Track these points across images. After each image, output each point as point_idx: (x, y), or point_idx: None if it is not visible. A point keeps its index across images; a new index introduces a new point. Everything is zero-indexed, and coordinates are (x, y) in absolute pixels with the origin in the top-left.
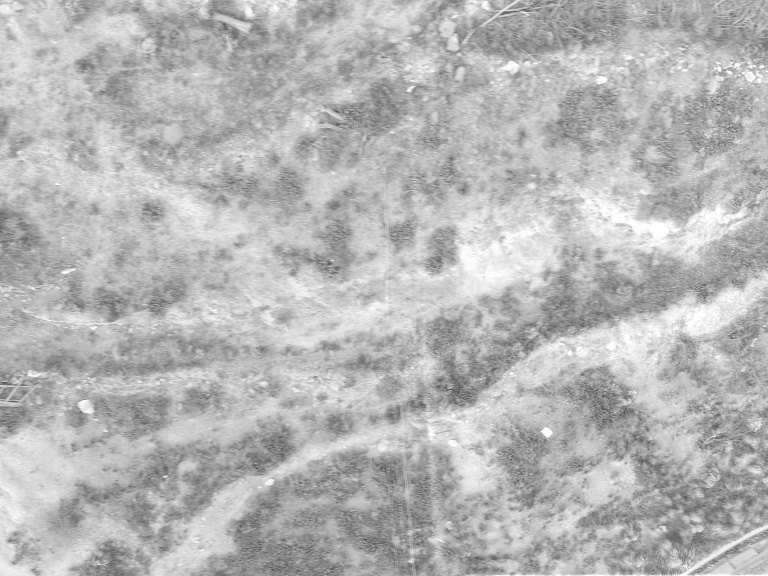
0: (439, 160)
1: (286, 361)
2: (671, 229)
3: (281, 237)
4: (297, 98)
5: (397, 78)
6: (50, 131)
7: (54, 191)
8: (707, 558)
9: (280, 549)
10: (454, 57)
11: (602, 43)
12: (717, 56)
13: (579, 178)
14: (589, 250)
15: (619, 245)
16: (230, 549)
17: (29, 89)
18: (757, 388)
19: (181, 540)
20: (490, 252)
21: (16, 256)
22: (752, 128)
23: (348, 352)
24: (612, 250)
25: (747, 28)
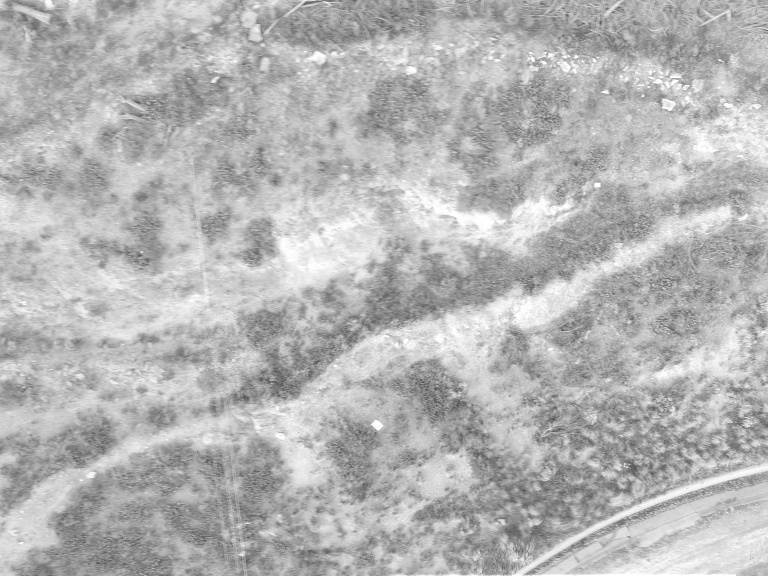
0: (249, 151)
1: (102, 353)
2: (496, 221)
3: (88, 229)
4: (97, 89)
5: (200, 69)
6: None
7: None
8: (550, 552)
9: (105, 542)
10: (258, 47)
11: (410, 33)
12: (530, 46)
13: (395, 169)
14: (415, 242)
15: (445, 237)
16: (53, 542)
17: None
18: (594, 381)
19: None
20: (311, 244)
21: None
22: (571, 119)
23: (167, 344)
24: (438, 242)
25: (560, 18)
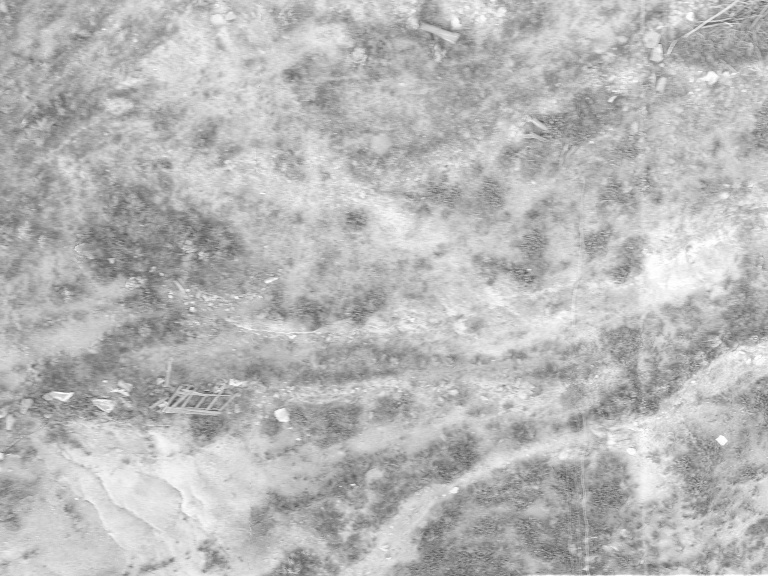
0: (635, 170)
1: (476, 370)
2: None
3: (480, 246)
4: (503, 108)
5: (600, 88)
6: (259, 141)
7: (258, 200)
8: None
9: (461, 557)
10: (656, 67)
11: None
12: None
13: None
14: None
15: None
16: (413, 557)
17: (237, 99)
18: None
19: (370, 548)
20: (675, 261)
21: (220, 265)
22: None
23: (535, 361)
24: None
25: None
